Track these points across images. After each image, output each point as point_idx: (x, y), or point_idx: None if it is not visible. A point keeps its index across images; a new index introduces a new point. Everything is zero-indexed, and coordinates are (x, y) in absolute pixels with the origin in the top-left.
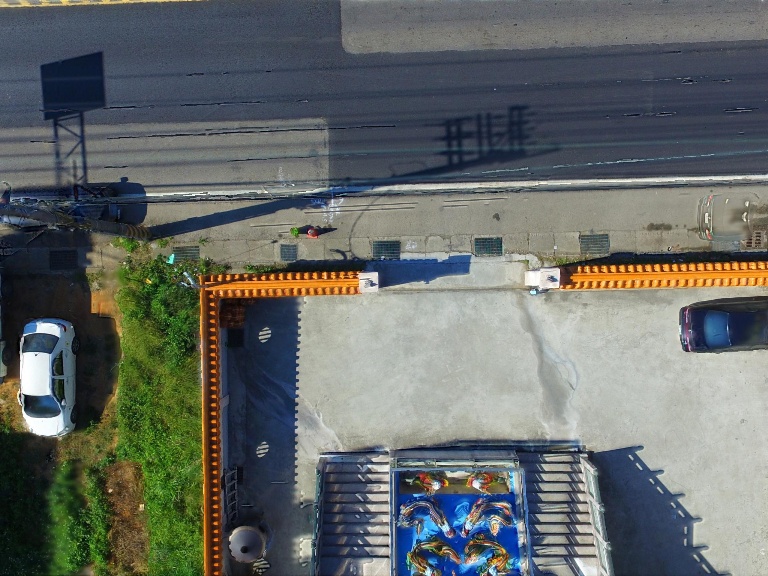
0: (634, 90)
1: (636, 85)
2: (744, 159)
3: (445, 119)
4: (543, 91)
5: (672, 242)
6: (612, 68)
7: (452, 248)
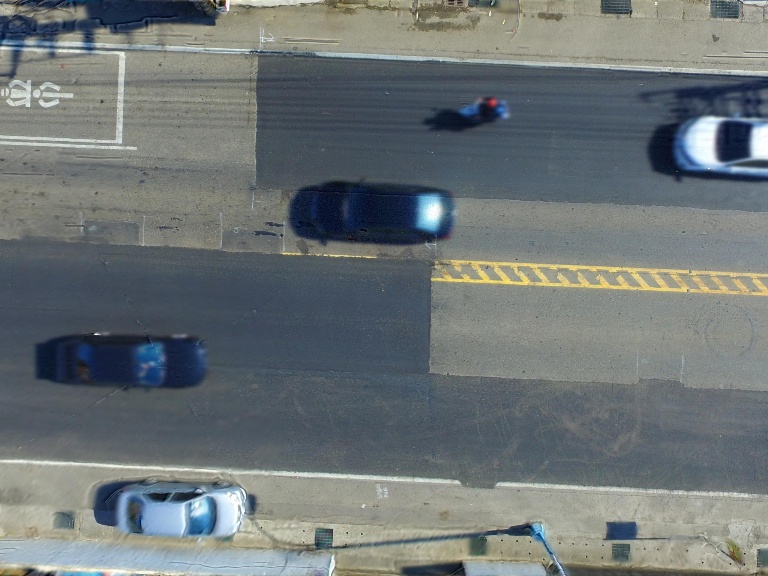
0: (569, 156)
1: (567, 161)
2: (464, 78)
3: (763, 142)
4: (661, 163)
5: (539, 1)
6: (590, 181)
7: (764, 10)
